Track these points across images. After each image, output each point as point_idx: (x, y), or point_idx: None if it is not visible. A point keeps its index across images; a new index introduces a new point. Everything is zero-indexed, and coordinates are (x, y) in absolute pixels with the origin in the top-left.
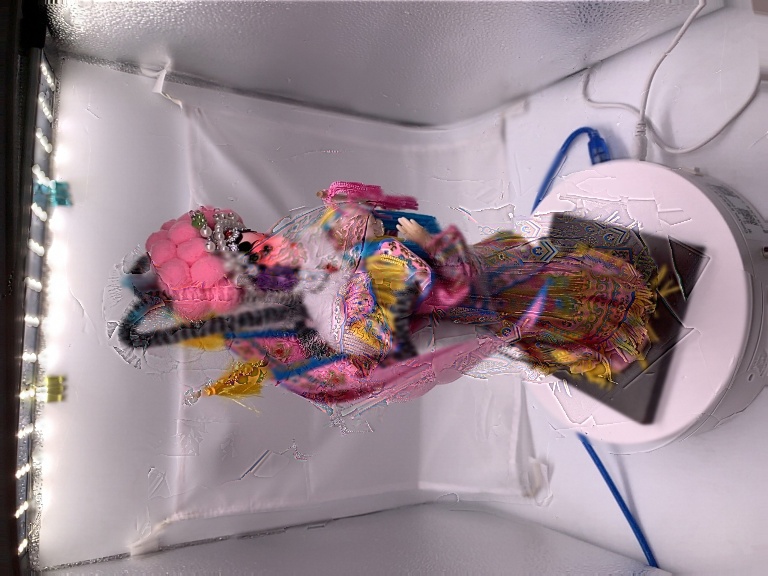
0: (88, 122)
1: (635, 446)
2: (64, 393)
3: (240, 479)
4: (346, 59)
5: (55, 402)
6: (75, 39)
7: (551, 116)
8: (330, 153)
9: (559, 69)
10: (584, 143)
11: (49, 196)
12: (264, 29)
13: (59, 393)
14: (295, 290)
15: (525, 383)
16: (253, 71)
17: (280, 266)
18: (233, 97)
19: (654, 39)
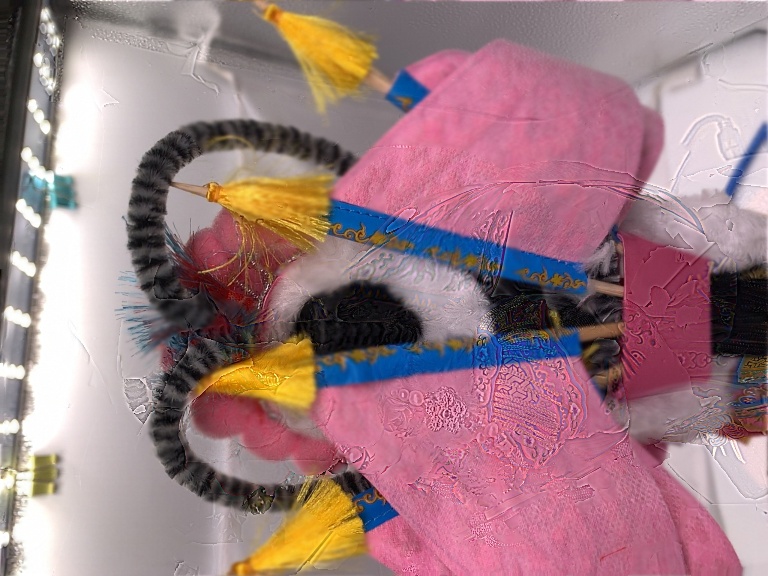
0: (100, 98)
1: None
2: (58, 480)
3: (296, 573)
4: (422, 31)
5: (44, 495)
6: (86, 7)
7: (675, 100)
8: (401, 148)
9: (681, 43)
10: (712, 135)
11: (44, 192)
12: None
13: (51, 480)
14: (409, 323)
15: None
16: (306, 47)
17: (397, 286)
18: (281, 80)
19: None
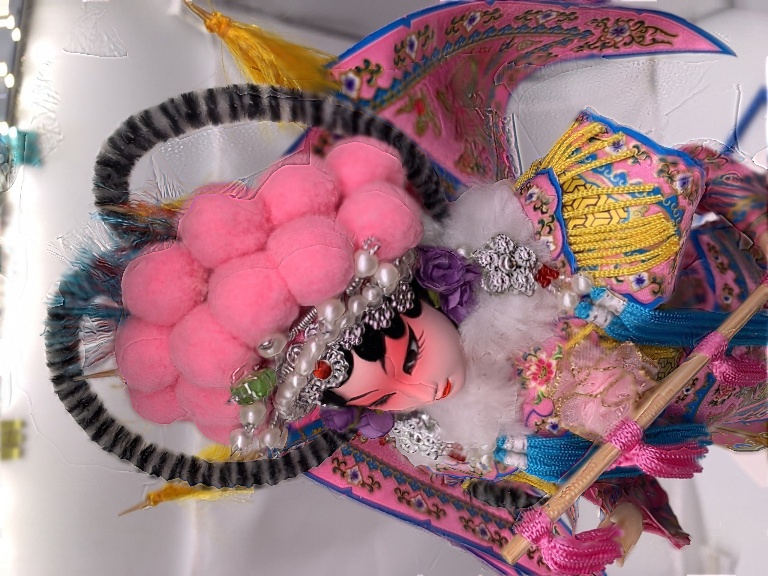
0: None
1: None
2: None
3: None
4: None
5: None
6: None
7: None
8: None
9: None
10: None
11: None
12: (278, 140)
13: None
14: None
15: None
16: None
17: (397, 129)
18: None
19: (712, 85)
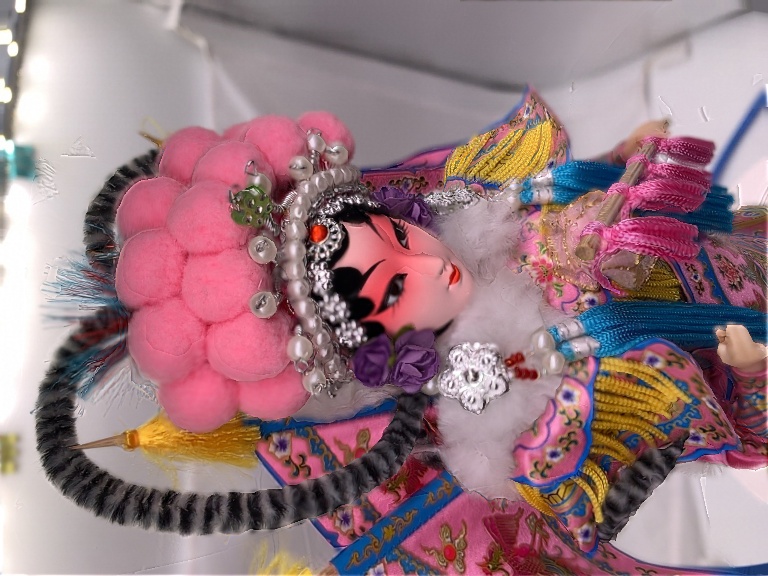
0: None
1: None
2: None
3: None
4: None
5: None
6: None
7: None
8: None
9: None
10: None
11: None
12: None
13: None
14: None
15: None
16: None
17: None
18: None
19: None
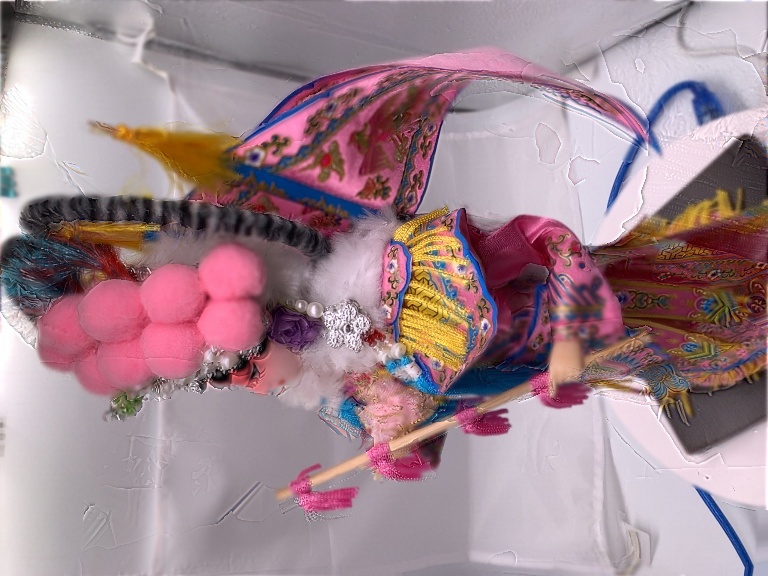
0: None
1: None
2: None
3: (217, 523)
4: None
5: None
6: None
7: None
8: None
9: None
10: None
11: None
12: None
13: None
14: None
15: (608, 403)
16: None
17: (297, 181)
18: (231, 6)
19: None
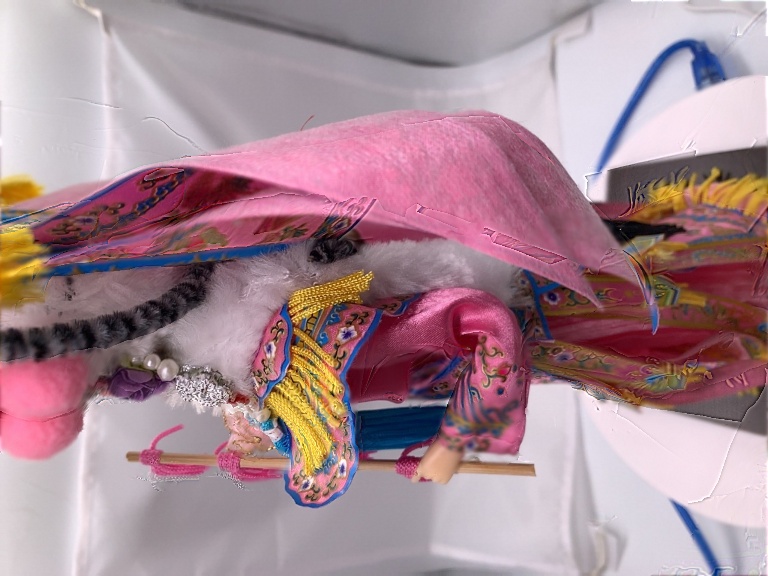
0: None
1: (650, 472)
2: None
3: None
4: None
5: None
6: None
7: None
8: None
9: None
10: None
11: None
12: None
13: None
14: None
15: None
16: None
17: None
18: None
19: None
